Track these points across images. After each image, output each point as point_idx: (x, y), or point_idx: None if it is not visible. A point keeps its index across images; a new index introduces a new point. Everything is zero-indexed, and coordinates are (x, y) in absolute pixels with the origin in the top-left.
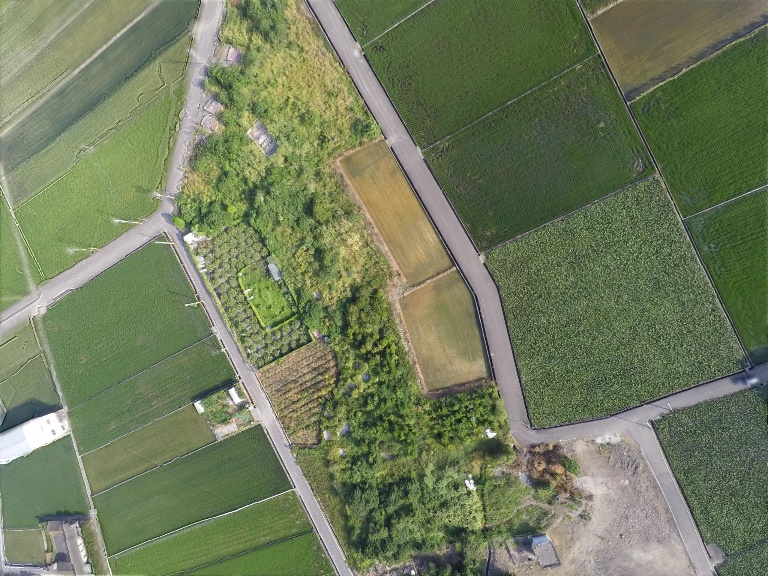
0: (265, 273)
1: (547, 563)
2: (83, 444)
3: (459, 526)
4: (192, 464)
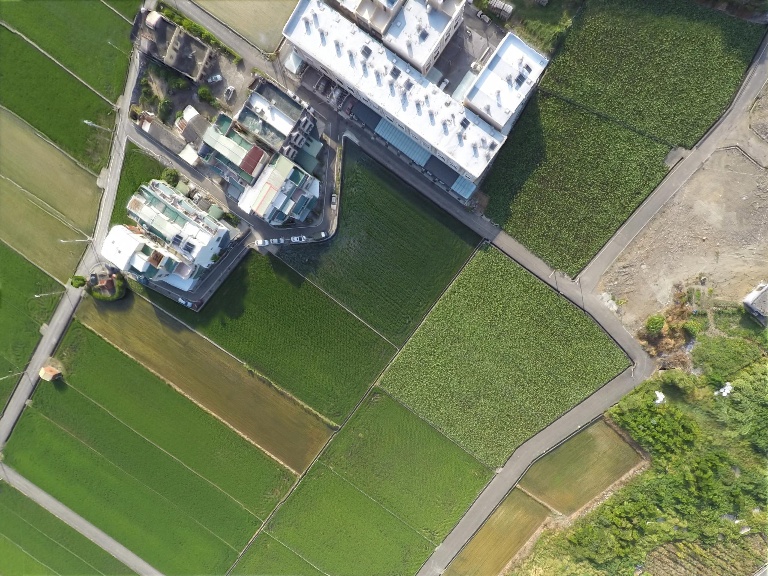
0: None
1: None
2: None
3: None
4: None
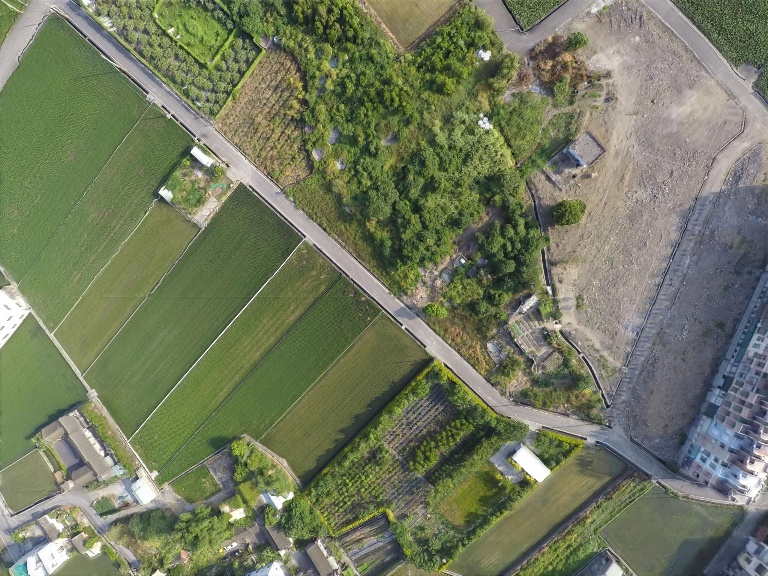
0: (183, 2)
1: (592, 159)
2: (50, 318)
3: (490, 175)
4: (183, 273)
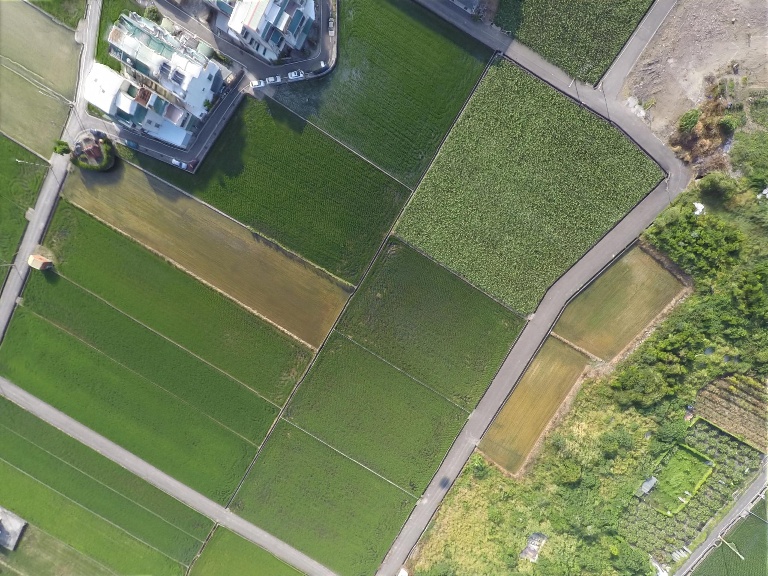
0: (653, 491)
1: None
2: None
3: None
4: None
